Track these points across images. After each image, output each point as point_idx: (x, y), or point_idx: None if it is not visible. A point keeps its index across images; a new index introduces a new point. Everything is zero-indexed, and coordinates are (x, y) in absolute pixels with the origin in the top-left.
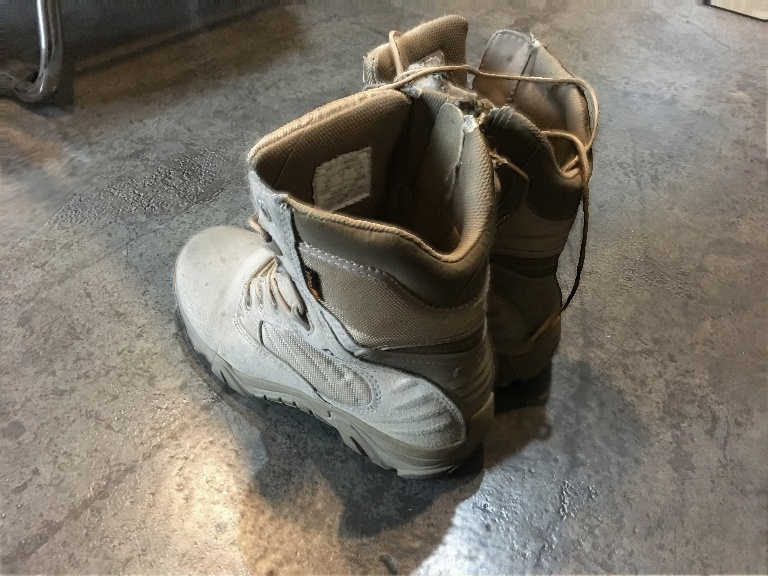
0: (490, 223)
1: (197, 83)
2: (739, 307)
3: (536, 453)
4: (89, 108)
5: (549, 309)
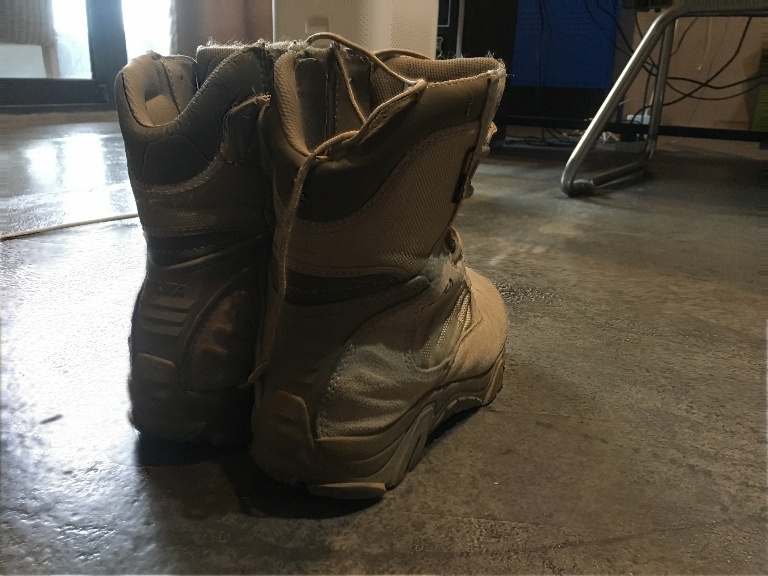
0: (186, 119)
1: (654, 279)
2: None
3: (162, 506)
4: (559, 255)
5: (281, 359)
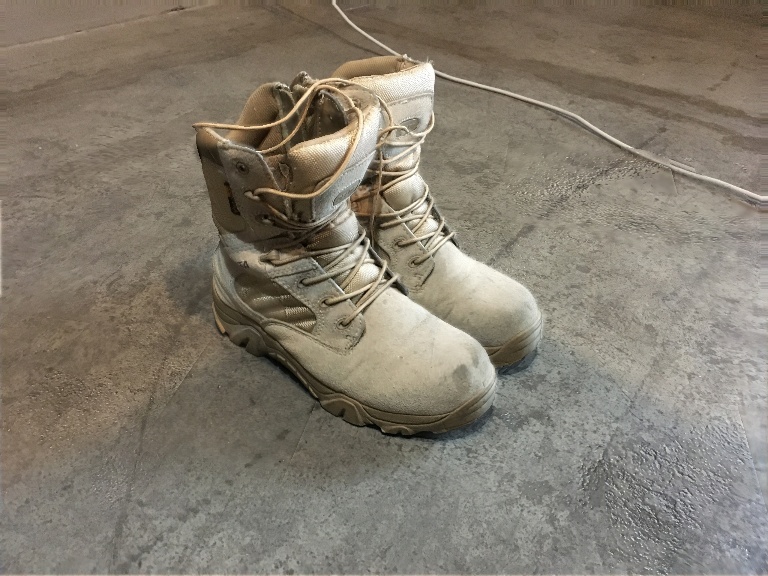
0: None
1: None
2: (8, 362)
3: None
4: None
5: None
